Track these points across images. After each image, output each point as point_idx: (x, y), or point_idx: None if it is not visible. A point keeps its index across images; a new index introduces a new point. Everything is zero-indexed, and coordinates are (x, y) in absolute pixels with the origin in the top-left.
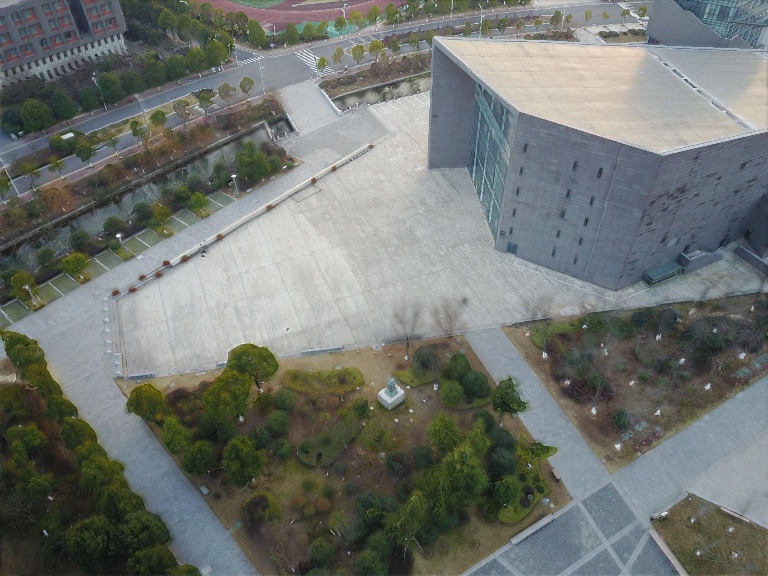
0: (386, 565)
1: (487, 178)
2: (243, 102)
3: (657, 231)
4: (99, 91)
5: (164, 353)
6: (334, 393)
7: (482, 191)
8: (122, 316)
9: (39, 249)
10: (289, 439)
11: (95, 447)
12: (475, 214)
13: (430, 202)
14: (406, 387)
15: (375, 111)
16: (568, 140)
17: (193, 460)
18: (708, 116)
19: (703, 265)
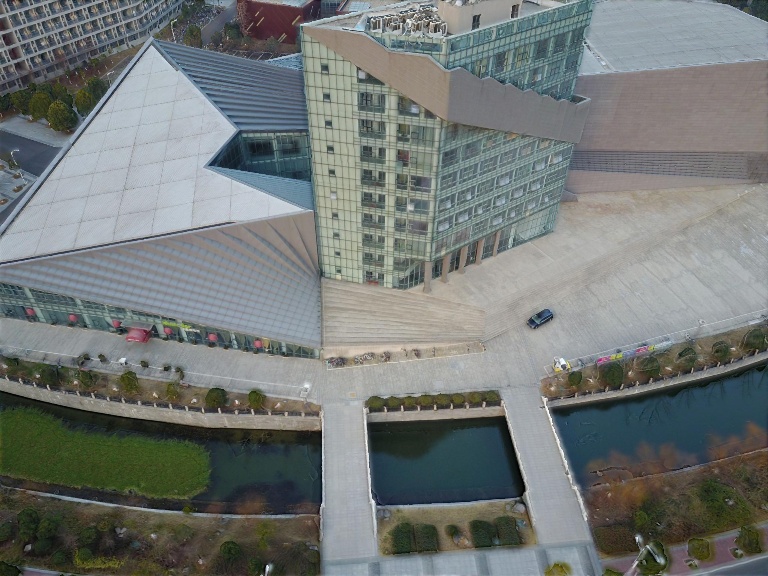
0: None
1: None
2: None
3: None
4: None
5: None
6: None
7: None
8: None
9: None
10: None
11: None
12: None
13: None
14: None
15: None
16: None
17: None
18: None
19: None
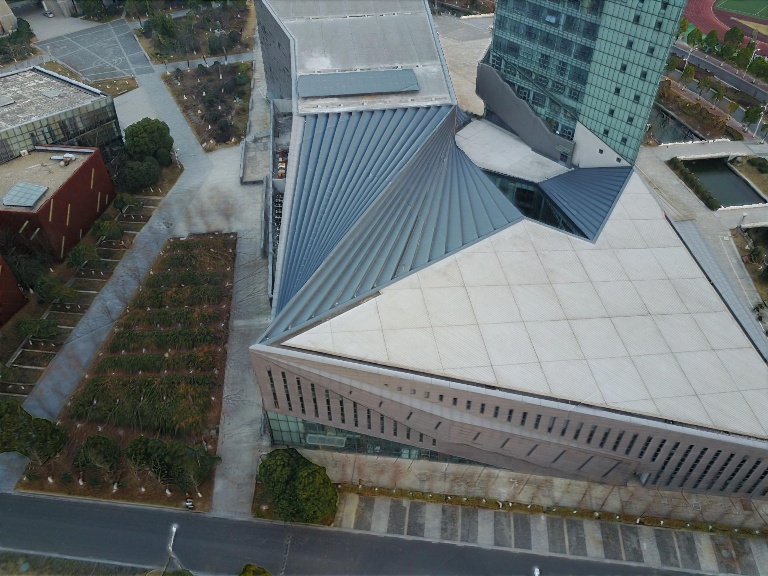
0: (148, 28)
1: None
2: None
3: None
4: None
5: None
6: None
7: None
8: None
9: None
10: None
11: None
12: None
13: None
14: None
15: None
16: None
17: None
18: (302, 10)
19: None
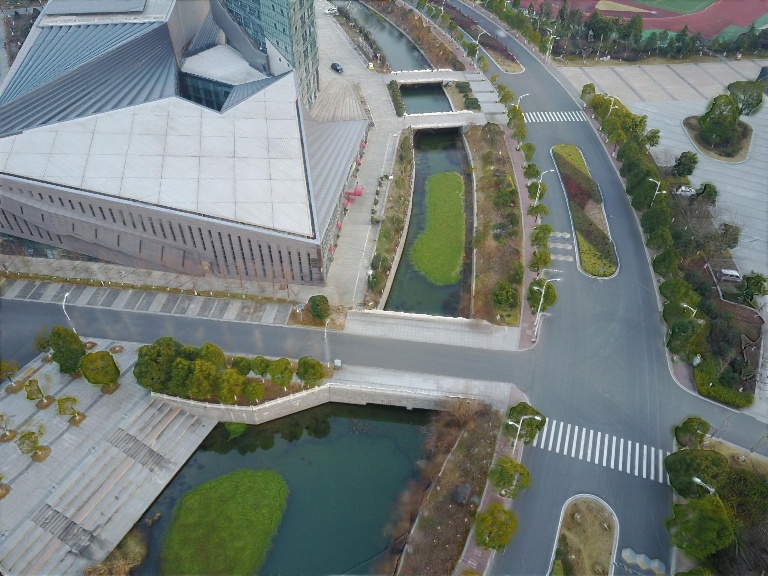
0: None
1: None
2: None
3: None
4: None
5: None
6: None
7: None
8: None
9: None
10: None
11: None
12: None
13: None
14: None
15: None
16: None
17: None
18: None
19: None
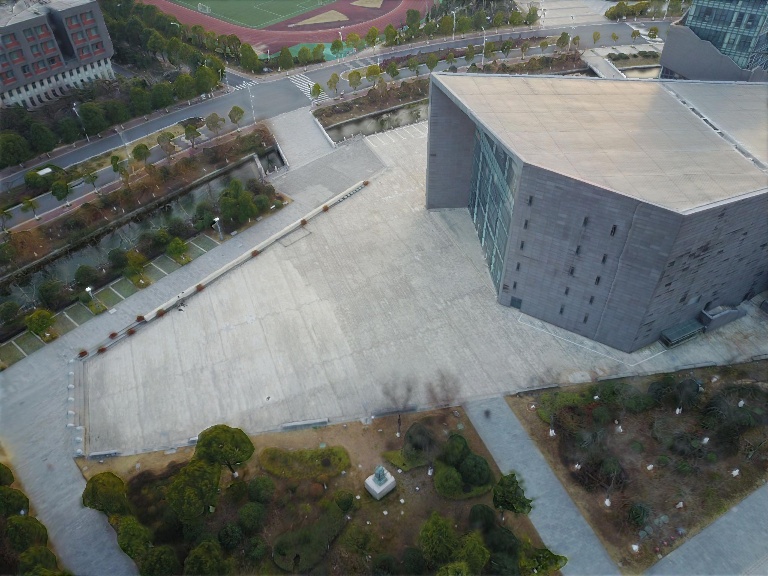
0: None
1: (489, 224)
2: (233, 132)
3: (676, 291)
4: (80, 122)
5: (131, 426)
6: (316, 479)
7: (484, 236)
8: (88, 381)
9: (2, 304)
10: (264, 537)
11: (41, 553)
12: (476, 262)
13: (428, 247)
14: (397, 471)
15: (371, 143)
16: (578, 194)
17: (151, 570)
18: (733, 164)
19: (726, 322)
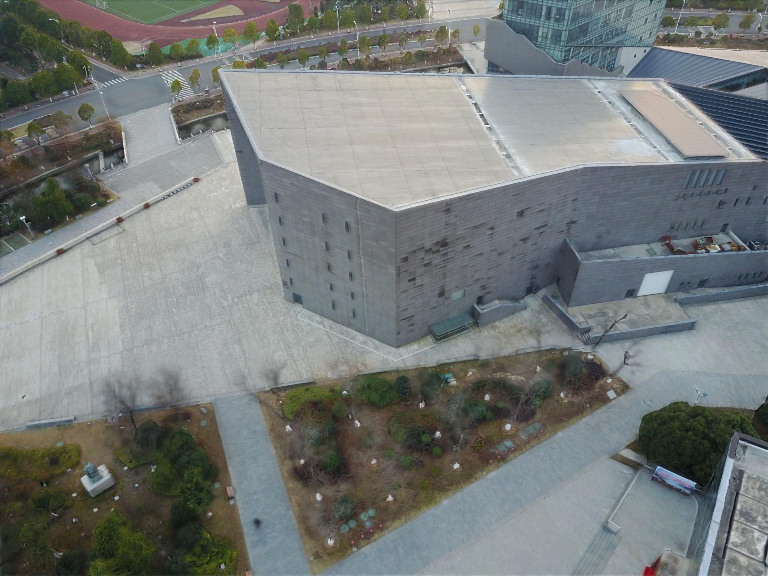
0: None
1: None
2: (85, 129)
3: (427, 286)
4: None
5: None
6: (37, 477)
7: None
8: None
9: None
10: None
11: None
12: (276, 258)
13: (234, 244)
14: (123, 468)
15: (218, 139)
16: (309, 191)
17: None
18: (480, 159)
19: (502, 316)
